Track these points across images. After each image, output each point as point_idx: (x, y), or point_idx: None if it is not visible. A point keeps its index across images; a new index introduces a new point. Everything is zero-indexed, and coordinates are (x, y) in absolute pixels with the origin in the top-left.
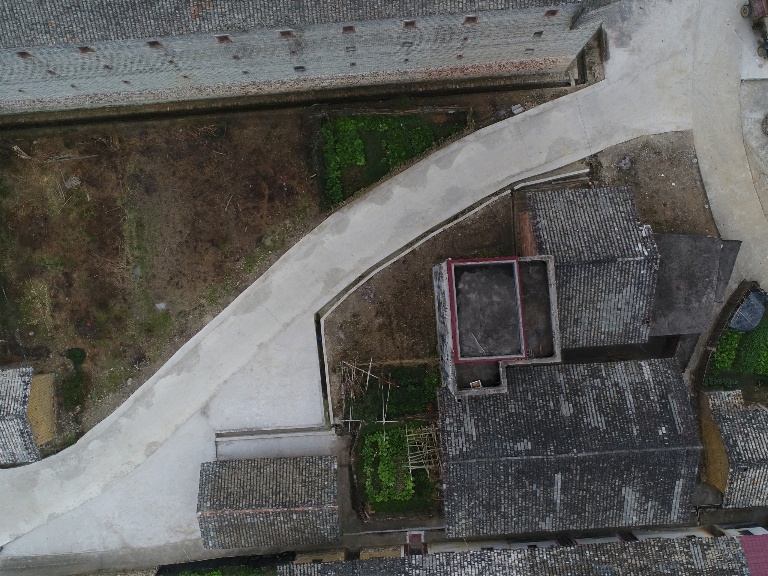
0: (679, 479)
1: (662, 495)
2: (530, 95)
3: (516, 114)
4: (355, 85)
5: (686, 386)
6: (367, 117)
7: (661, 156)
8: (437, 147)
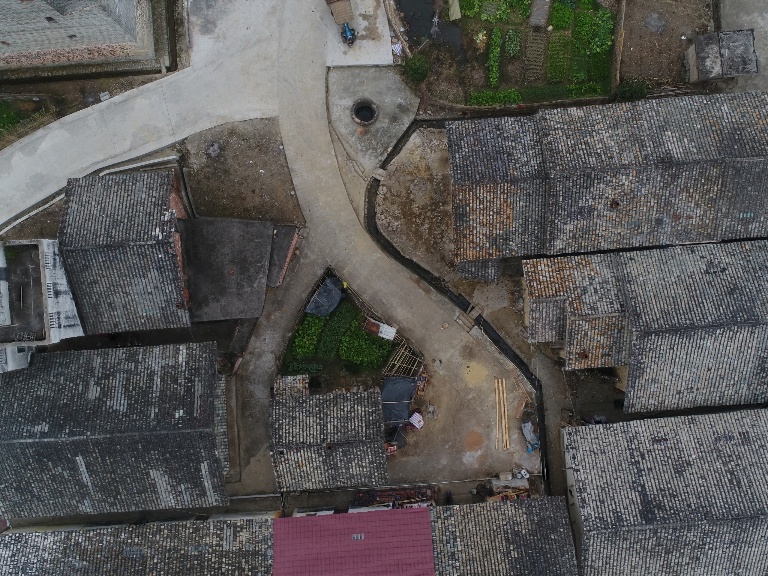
0: (203, 461)
1: (191, 477)
2: (120, 82)
3: (101, 101)
4: None
5: (271, 371)
6: None
7: (249, 143)
8: (11, 134)
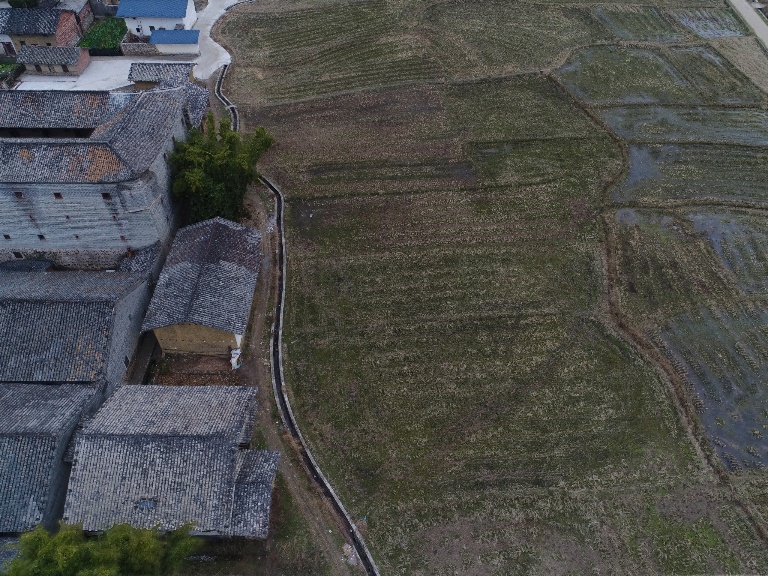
0: None
1: None
2: None
3: None
4: None
5: None
6: None
7: None
8: None
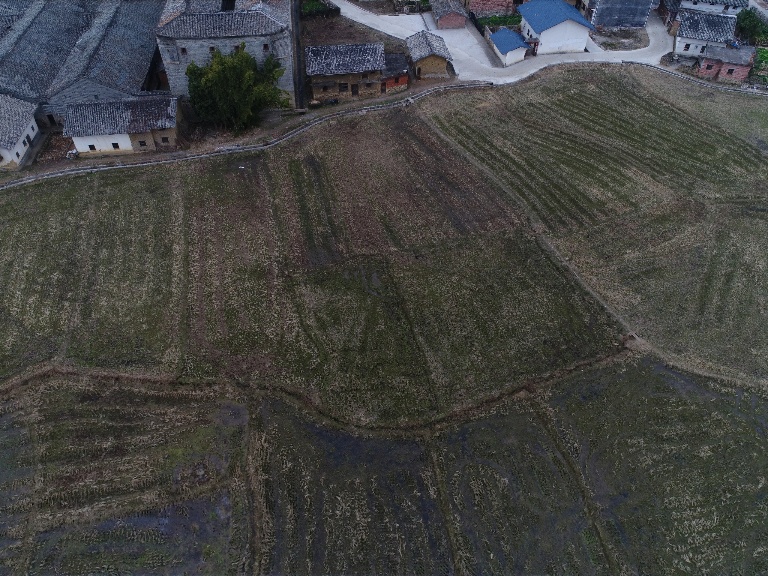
0: None
1: None
2: None
3: None
4: None
5: None
6: None
7: None
8: None
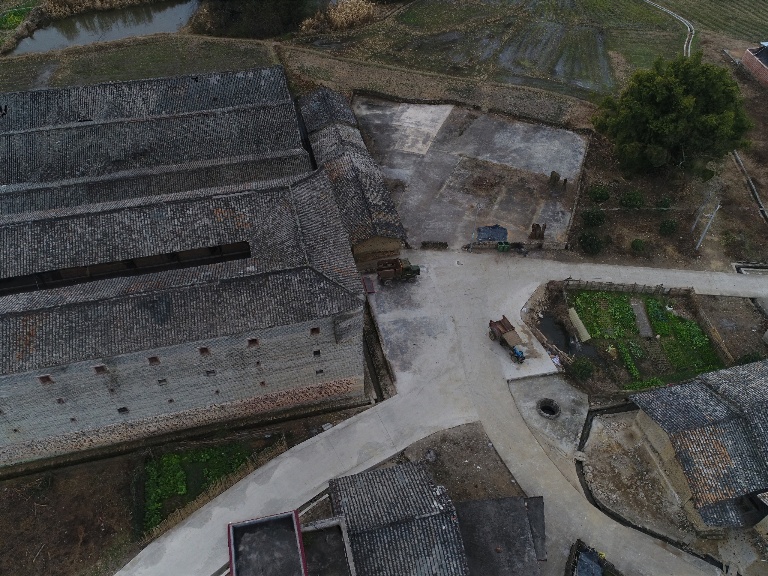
0: None
1: None
2: (338, 415)
3: (326, 430)
4: (182, 428)
5: None
6: (191, 451)
7: (460, 446)
8: (252, 463)
